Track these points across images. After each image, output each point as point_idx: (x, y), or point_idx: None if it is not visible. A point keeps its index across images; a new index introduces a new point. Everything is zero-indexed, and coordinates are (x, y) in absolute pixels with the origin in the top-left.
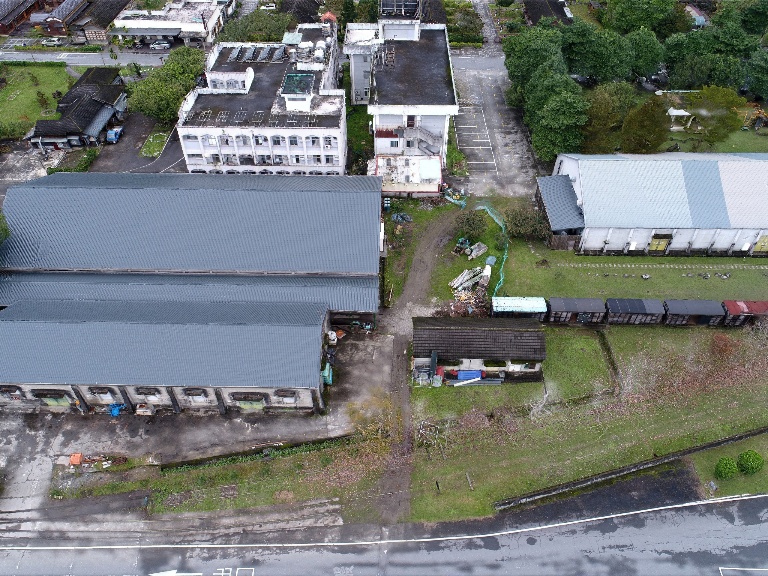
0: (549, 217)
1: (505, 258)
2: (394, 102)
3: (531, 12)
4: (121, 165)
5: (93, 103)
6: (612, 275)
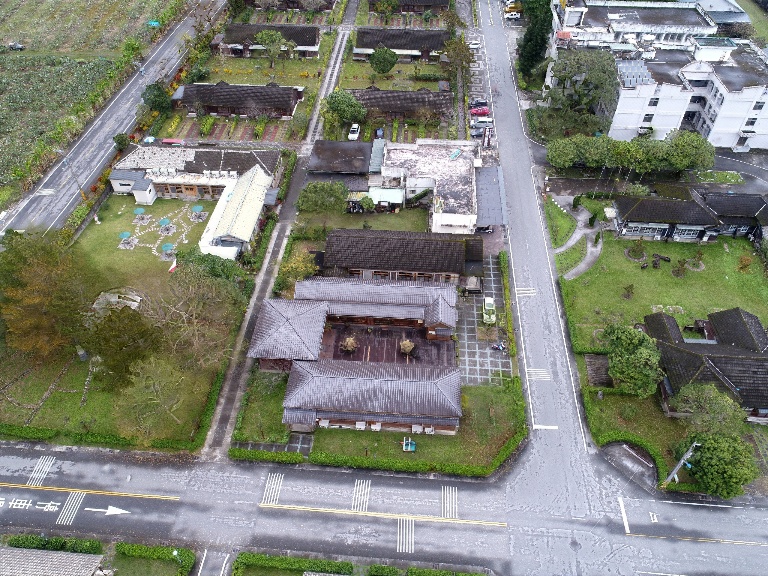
0: (740, 21)
1: (765, 46)
2: (695, 24)
3: (415, 2)
4: (766, 191)
5: (714, 193)
6: (751, 27)
